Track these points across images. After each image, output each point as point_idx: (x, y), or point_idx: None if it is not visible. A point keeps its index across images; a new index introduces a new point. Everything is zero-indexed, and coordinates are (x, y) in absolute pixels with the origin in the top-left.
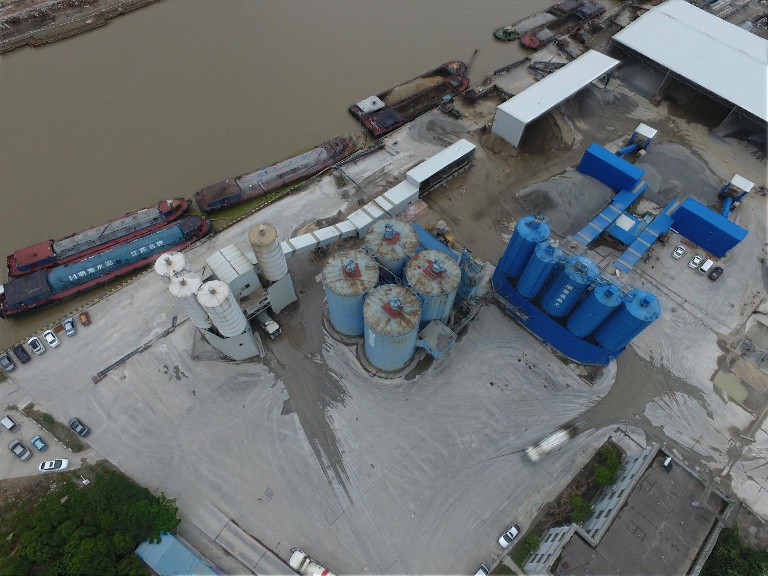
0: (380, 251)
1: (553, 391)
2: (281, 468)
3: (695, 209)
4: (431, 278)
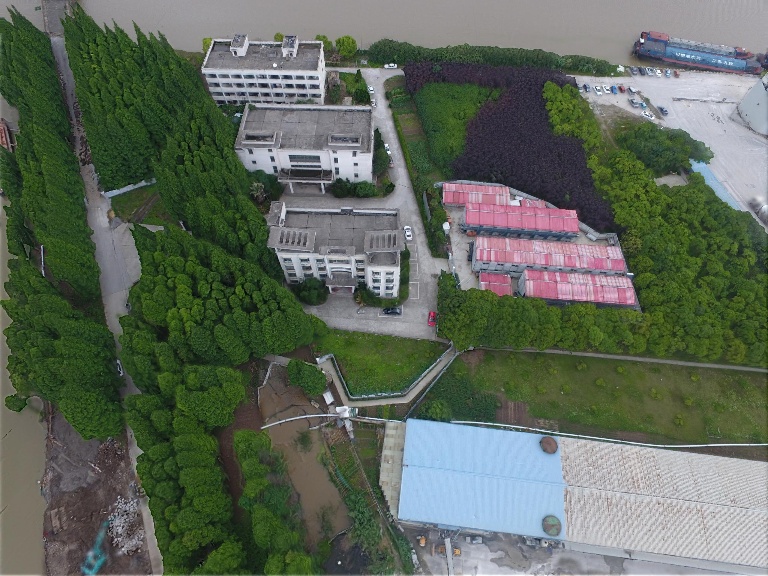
0: None
1: None
2: (764, 182)
3: None
4: None
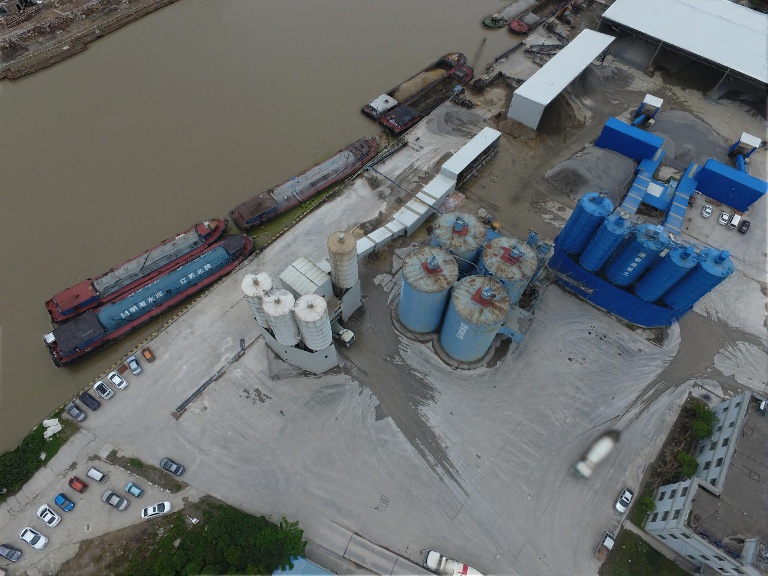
0: (453, 244)
1: (628, 357)
2: (390, 473)
3: (718, 169)
4: (510, 264)
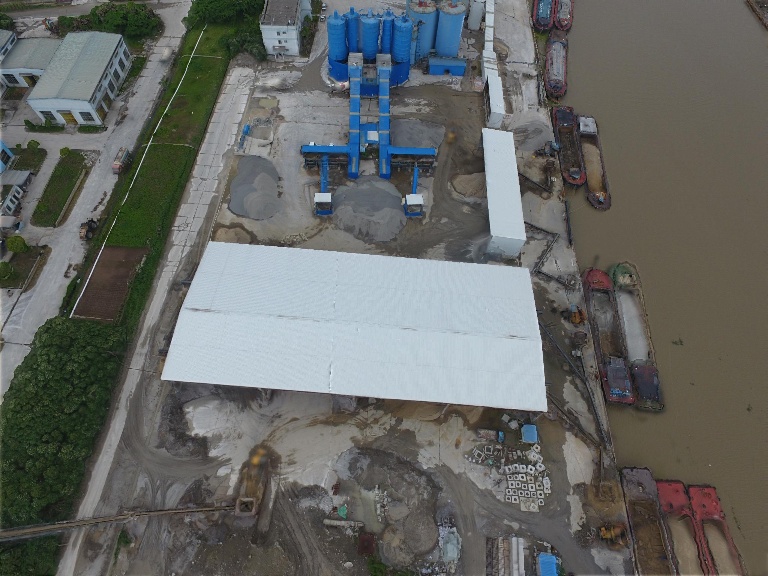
0: None
1: None
2: None
3: (341, 148)
4: None
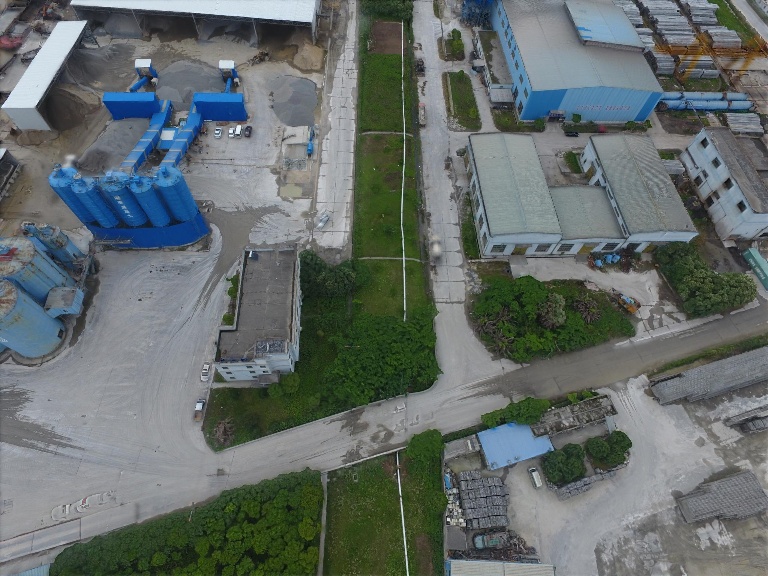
0: None
1: (185, 273)
2: (6, 480)
3: (203, 99)
4: (7, 261)
